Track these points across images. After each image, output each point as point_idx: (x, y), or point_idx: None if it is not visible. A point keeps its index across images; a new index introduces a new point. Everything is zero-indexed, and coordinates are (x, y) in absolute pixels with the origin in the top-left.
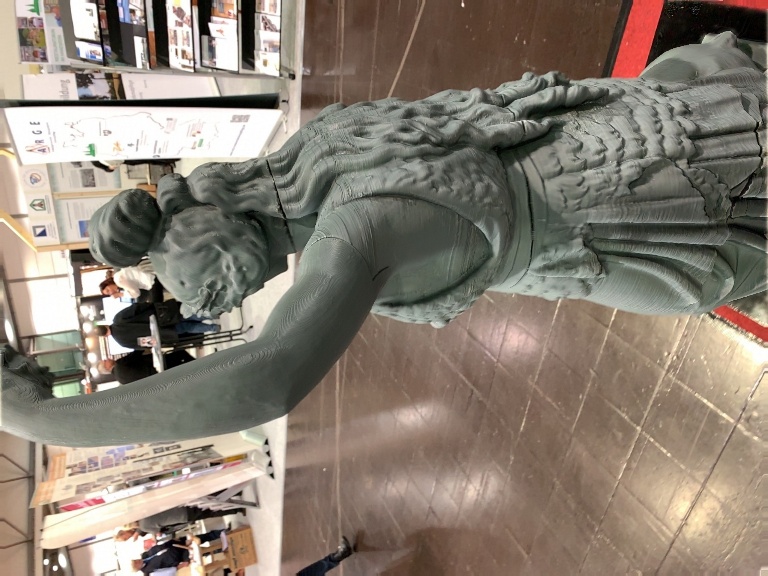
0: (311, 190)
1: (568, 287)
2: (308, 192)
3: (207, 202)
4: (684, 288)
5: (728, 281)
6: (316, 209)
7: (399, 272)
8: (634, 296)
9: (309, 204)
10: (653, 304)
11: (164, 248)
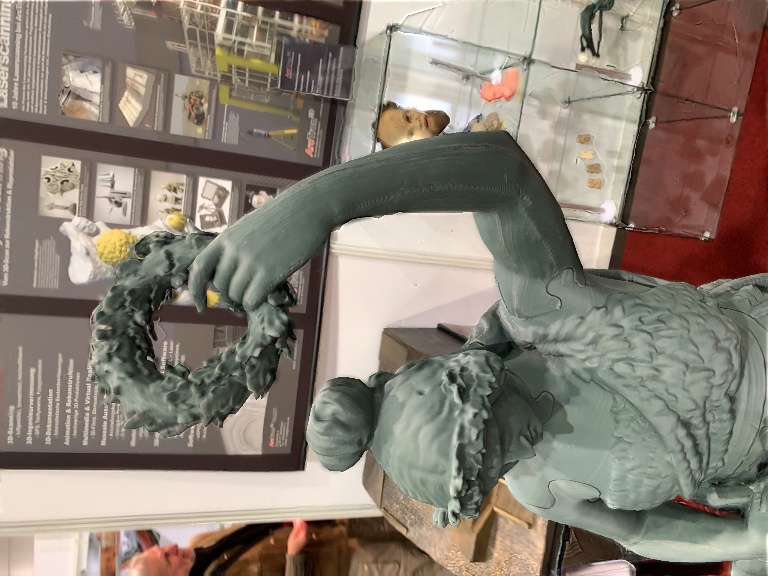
0: (485, 319)
1: None
2: (484, 321)
3: (410, 365)
4: None
5: None
6: (503, 331)
7: None
8: None
9: (491, 324)
10: None
11: (388, 392)
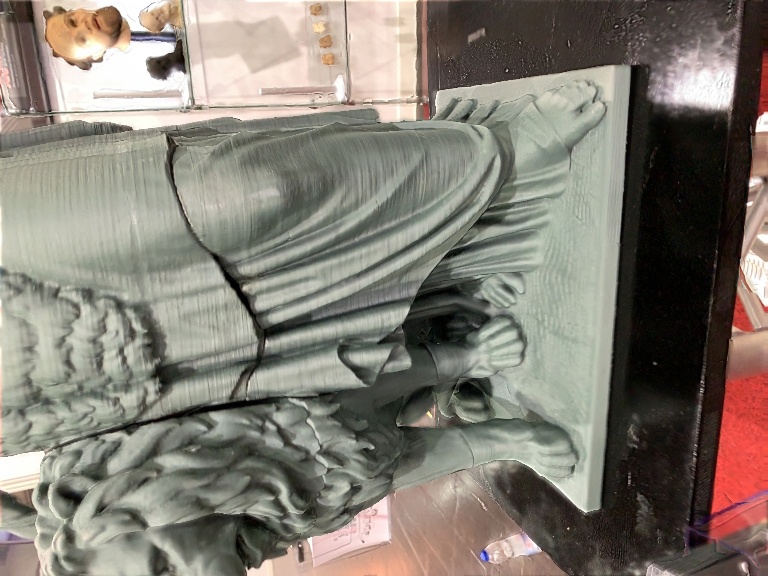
0: None
1: None
2: None
3: None
4: (124, 144)
5: None
6: None
7: None
8: (31, 171)
9: None
10: (87, 167)
11: None
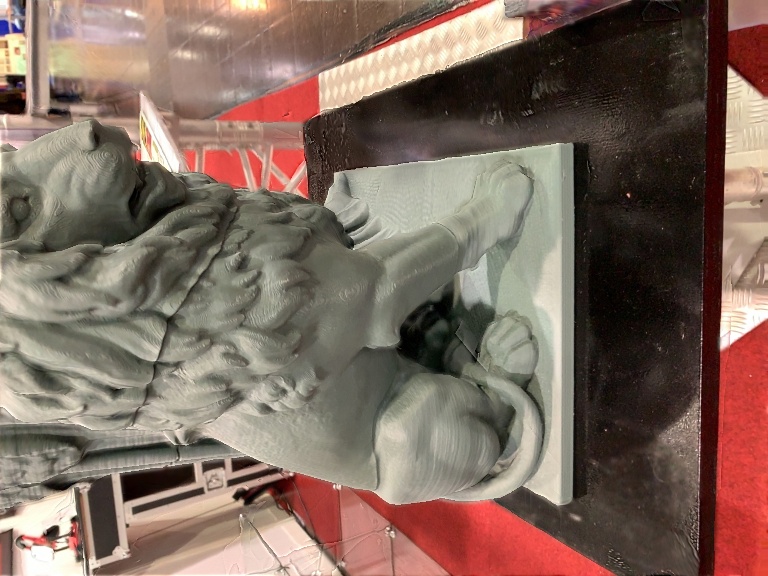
0: None
1: None
2: None
3: None
4: None
5: None
6: None
7: None
8: None
9: None
10: None
11: None
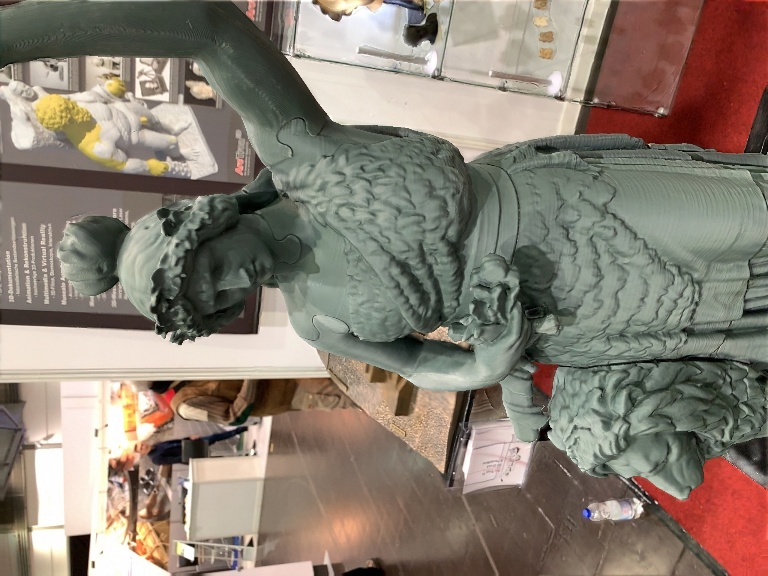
0: None
1: (571, 177)
2: None
3: None
4: (710, 170)
5: (767, 178)
6: (271, 182)
7: (347, 135)
8: (667, 180)
9: None
10: (708, 186)
11: None
